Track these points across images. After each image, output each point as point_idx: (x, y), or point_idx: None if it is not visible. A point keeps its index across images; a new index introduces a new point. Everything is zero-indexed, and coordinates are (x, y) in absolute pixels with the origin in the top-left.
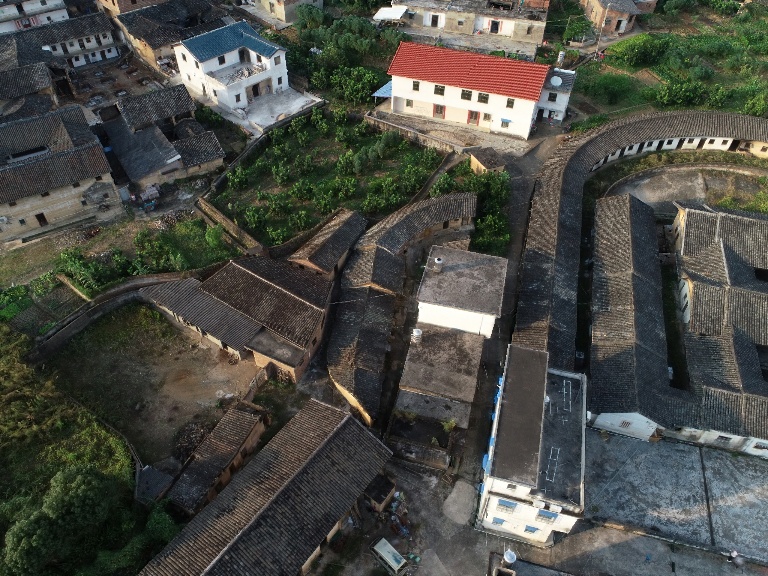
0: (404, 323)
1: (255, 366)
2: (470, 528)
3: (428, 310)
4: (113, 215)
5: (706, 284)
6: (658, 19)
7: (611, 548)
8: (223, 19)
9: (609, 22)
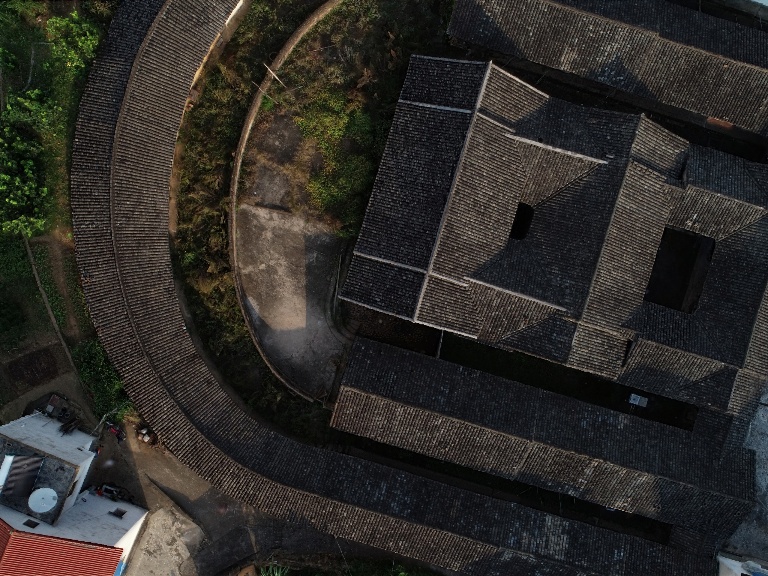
0: None
1: None
2: None
3: None
4: None
5: None
6: None
7: None
8: None
9: None
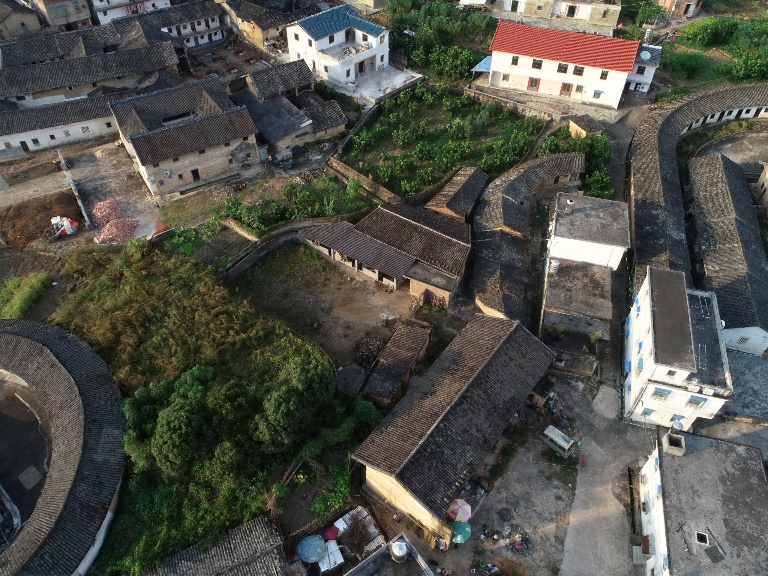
0: (531, 262)
1: (409, 295)
2: (619, 421)
3: (563, 245)
4: (255, 172)
5: None
6: (721, 5)
7: (743, 437)
8: (318, 5)
9: (678, 6)
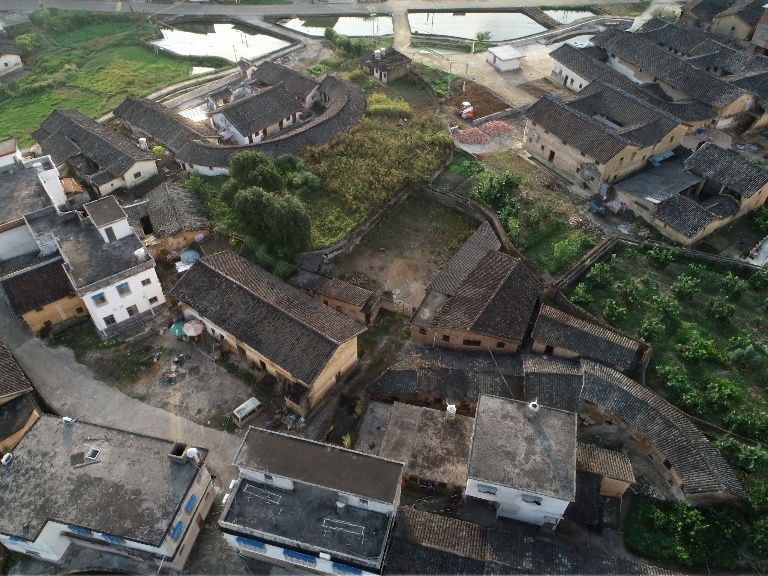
0: None
1: None
2: None
3: None
4: (578, 193)
5: None
6: None
7: None
8: None
9: None
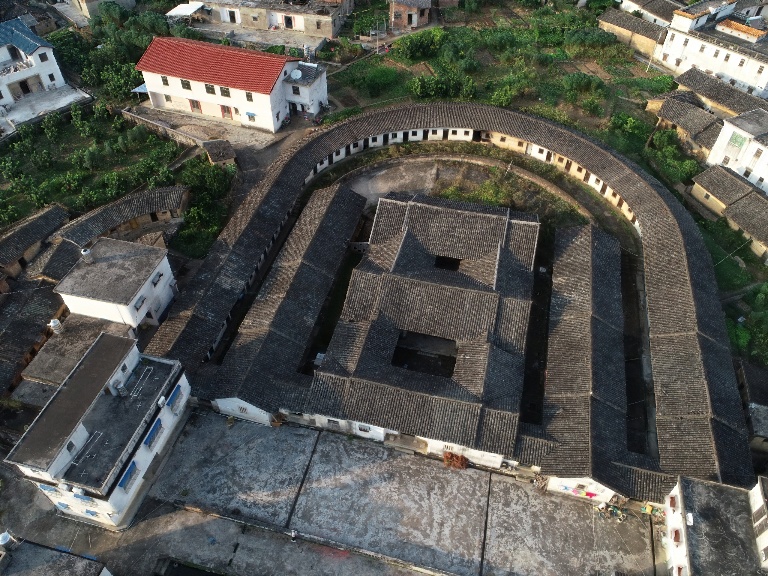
0: None
1: None
2: (53, 514)
3: (71, 301)
4: None
5: (363, 271)
6: (460, 13)
7: (183, 530)
8: (22, 17)
9: (400, 16)
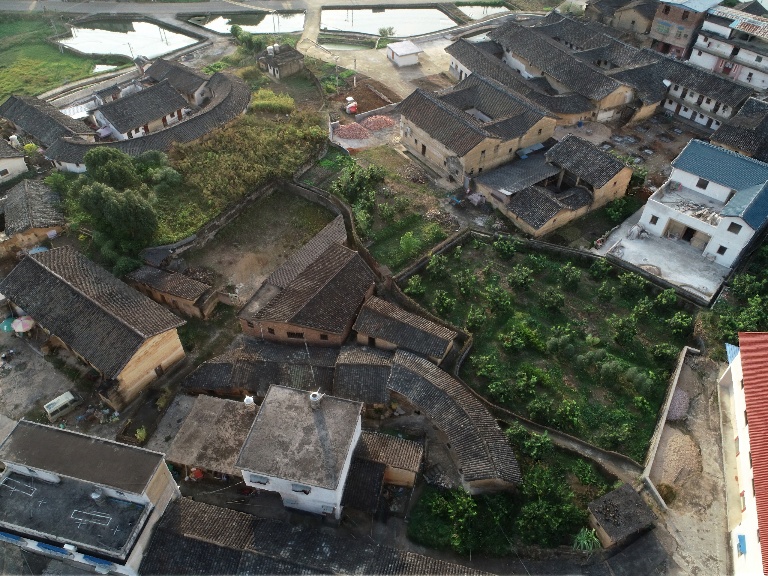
0: None
1: None
2: None
3: None
4: (444, 186)
5: None
6: None
7: None
8: None
9: None
